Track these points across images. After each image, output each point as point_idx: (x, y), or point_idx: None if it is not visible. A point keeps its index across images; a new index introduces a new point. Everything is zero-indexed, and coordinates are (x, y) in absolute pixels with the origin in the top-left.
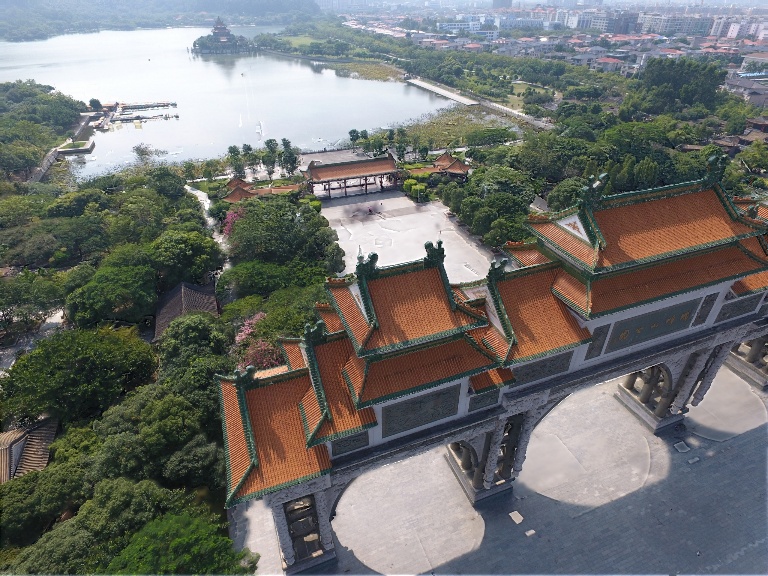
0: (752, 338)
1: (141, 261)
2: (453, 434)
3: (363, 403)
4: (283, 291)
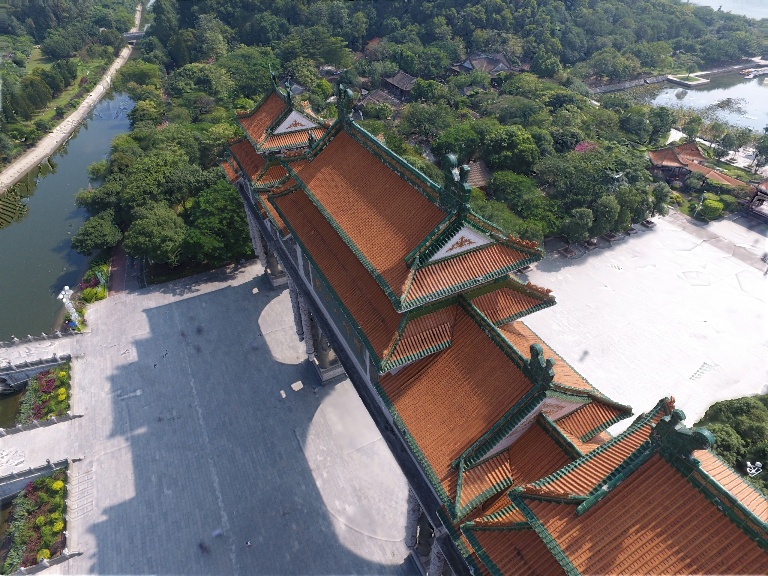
0: None
1: (480, 132)
2: None
3: (228, 148)
4: (499, 204)
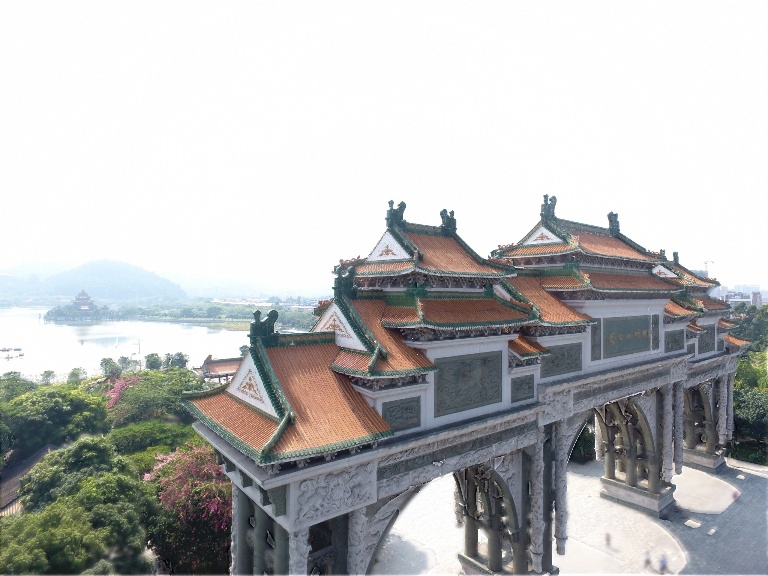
0: (692, 384)
1: None
2: (500, 439)
3: (427, 321)
4: None
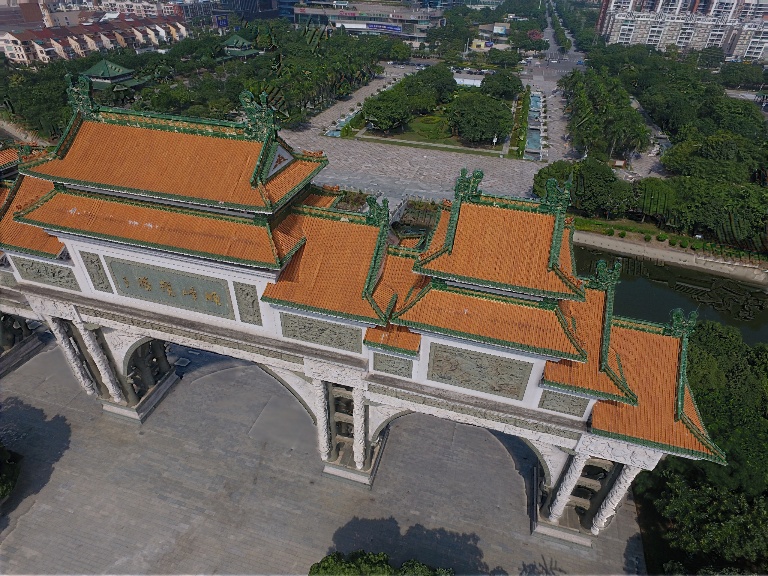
0: None
1: None
2: None
3: None
4: None
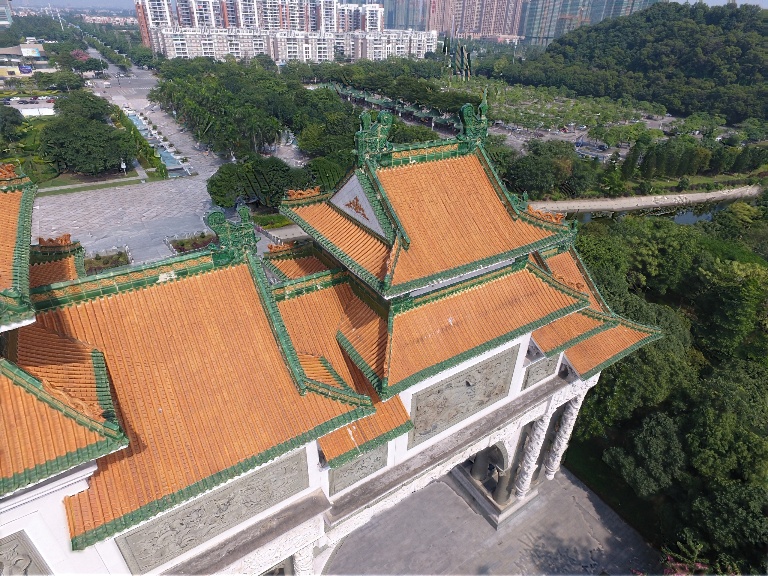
0: None
1: None
2: None
3: None
4: None
